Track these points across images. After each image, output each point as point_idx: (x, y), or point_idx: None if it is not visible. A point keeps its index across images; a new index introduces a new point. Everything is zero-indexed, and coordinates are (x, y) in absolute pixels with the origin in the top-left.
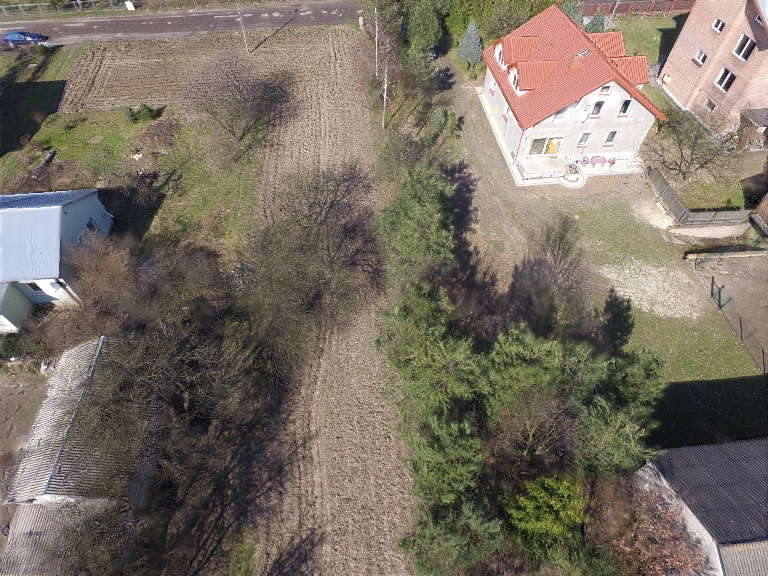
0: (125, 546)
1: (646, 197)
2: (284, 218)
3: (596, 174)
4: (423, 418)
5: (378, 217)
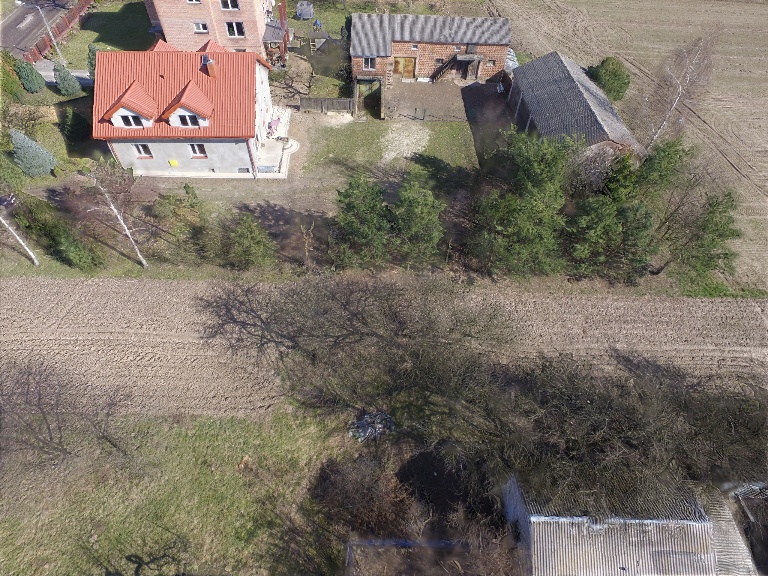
0: (728, 411)
1: (319, 117)
2: (277, 383)
3: (286, 132)
4: (557, 246)
5: (300, 286)
